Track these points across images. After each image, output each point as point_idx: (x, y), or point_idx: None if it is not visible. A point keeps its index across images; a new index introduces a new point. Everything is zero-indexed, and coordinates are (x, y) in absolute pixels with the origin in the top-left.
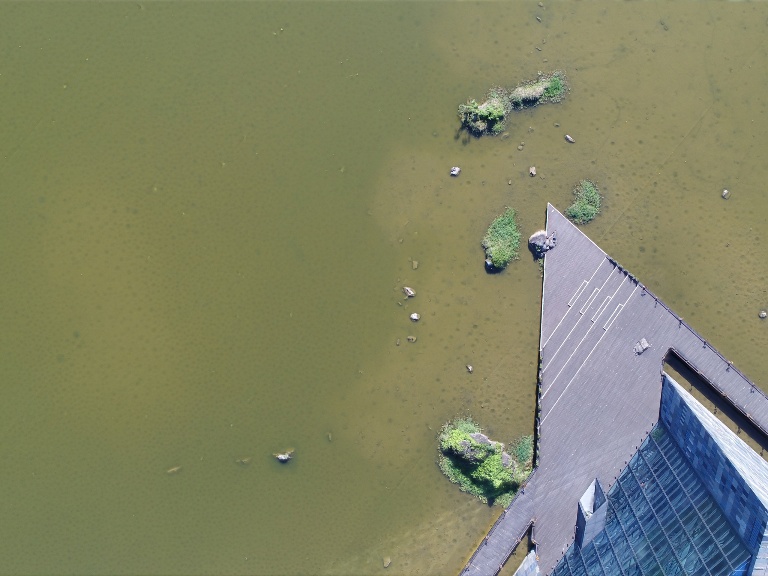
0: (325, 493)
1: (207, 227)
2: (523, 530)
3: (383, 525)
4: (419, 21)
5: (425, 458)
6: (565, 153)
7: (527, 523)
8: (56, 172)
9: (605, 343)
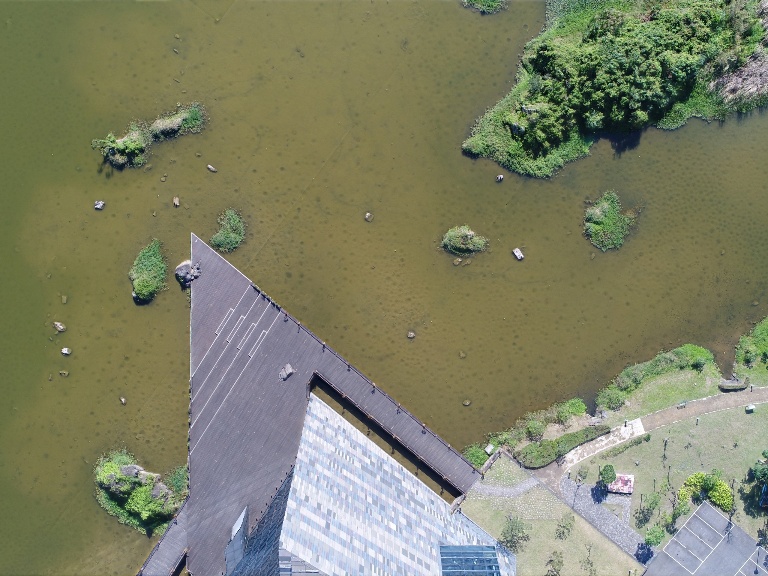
0: None
1: None
2: (177, 560)
3: (44, 561)
4: (58, 57)
5: (83, 492)
6: (208, 183)
7: (181, 553)
8: None
9: (250, 370)
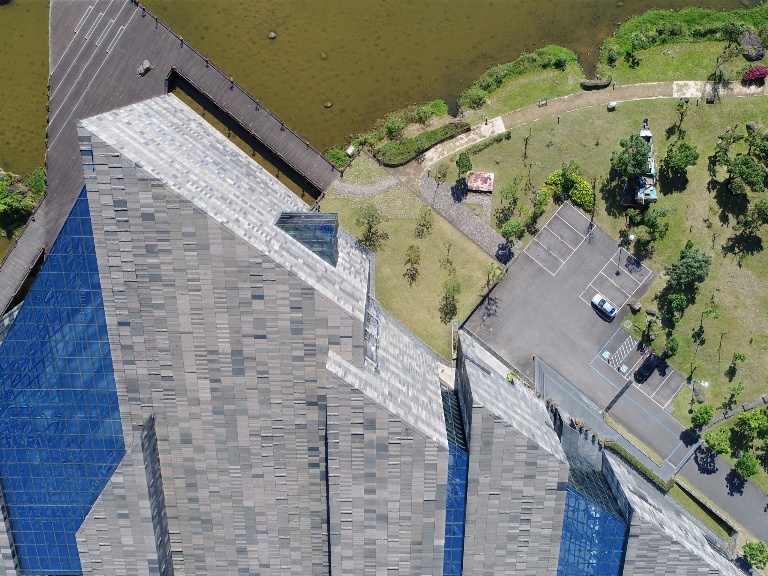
0: None
1: None
2: (35, 258)
3: None
4: None
5: None
6: None
7: (39, 250)
8: None
9: (108, 66)
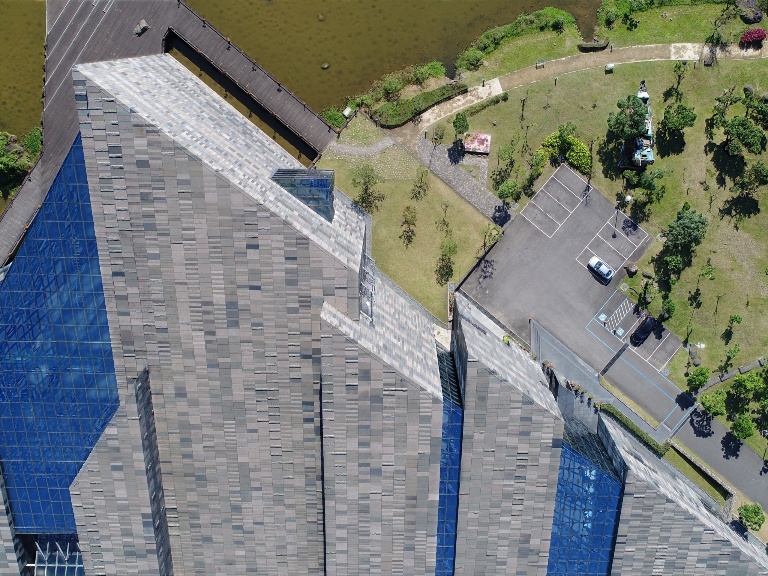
0: None
1: None
2: (31, 217)
3: None
4: None
5: None
6: None
7: (35, 210)
8: None
9: (105, 26)
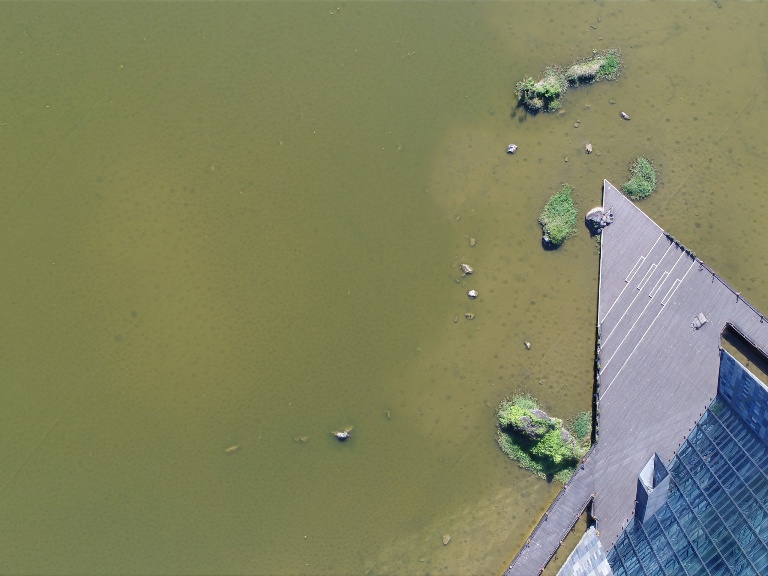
0: (384, 471)
1: (265, 206)
2: (583, 506)
3: (442, 502)
4: None
5: (484, 435)
6: (621, 130)
7: (587, 499)
8: (113, 152)
9: (663, 318)
